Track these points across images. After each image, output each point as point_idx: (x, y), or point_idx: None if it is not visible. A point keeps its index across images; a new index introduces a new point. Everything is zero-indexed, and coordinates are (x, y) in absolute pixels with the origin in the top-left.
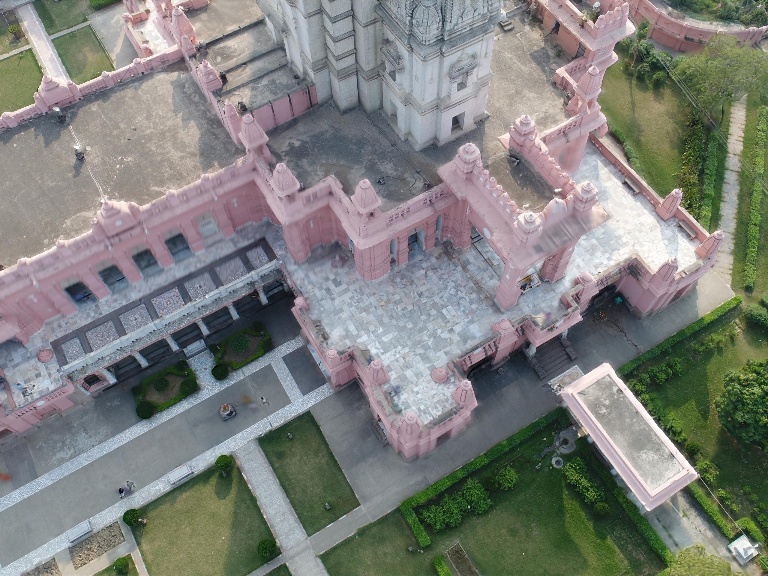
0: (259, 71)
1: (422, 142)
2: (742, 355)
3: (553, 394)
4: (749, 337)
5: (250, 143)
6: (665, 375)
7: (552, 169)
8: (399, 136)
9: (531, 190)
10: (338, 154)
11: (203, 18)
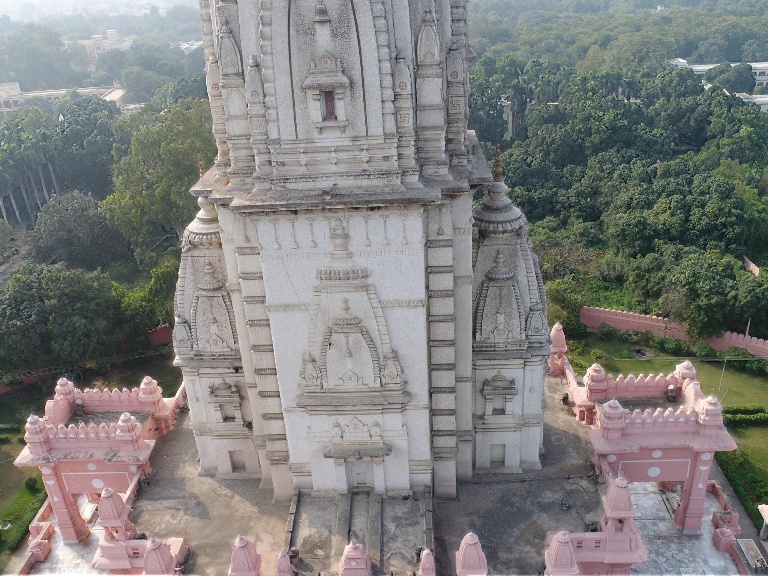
0: (374, 522)
1: (538, 458)
2: (750, 445)
3: (767, 570)
4: (734, 434)
5: (484, 567)
6: (767, 487)
7: (645, 383)
8: (514, 473)
9: (652, 407)
10: (509, 525)
11: (205, 562)
